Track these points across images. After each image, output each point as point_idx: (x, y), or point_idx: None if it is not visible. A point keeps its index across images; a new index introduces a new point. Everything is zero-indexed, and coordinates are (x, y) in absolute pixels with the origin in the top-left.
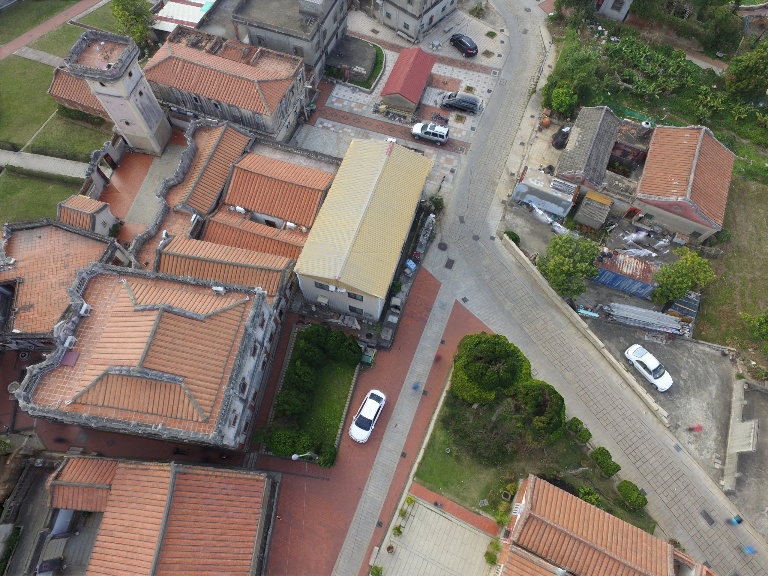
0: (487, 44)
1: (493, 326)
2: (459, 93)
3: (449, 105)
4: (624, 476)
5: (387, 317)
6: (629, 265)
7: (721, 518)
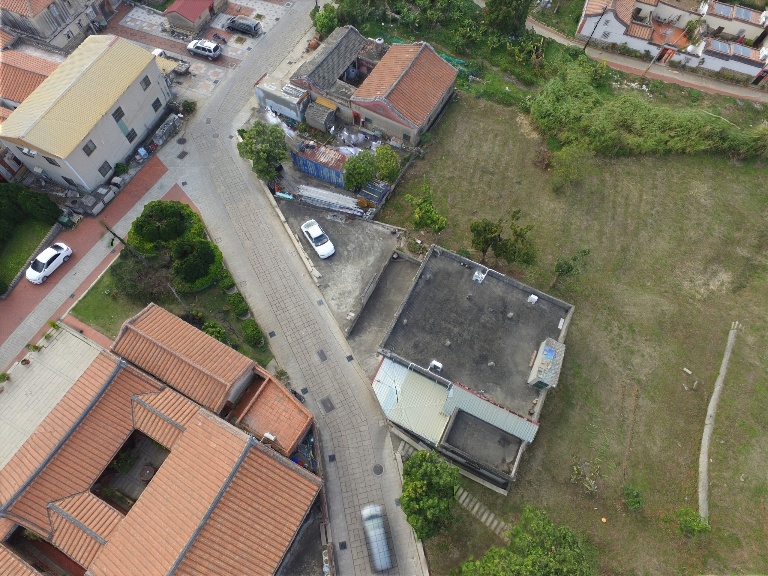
0: None
1: (199, 204)
2: (238, 16)
3: (231, 28)
4: (261, 321)
5: (97, 189)
6: (327, 155)
7: (334, 357)
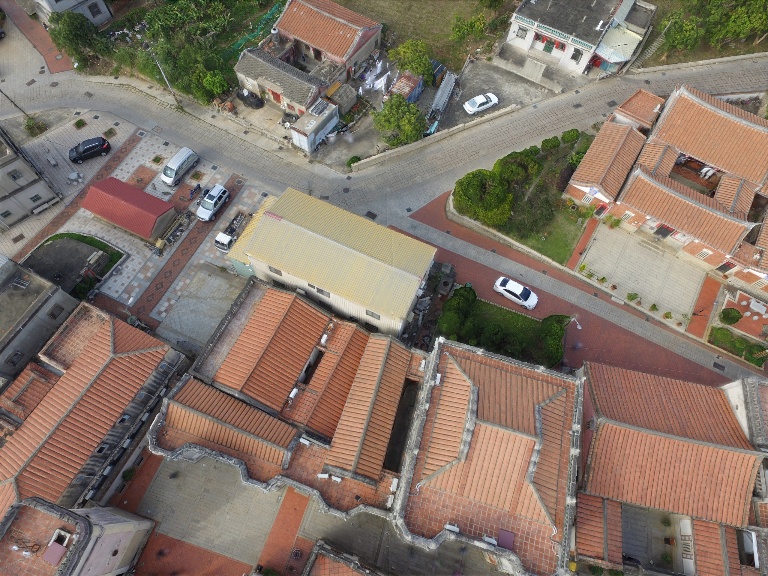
0: (94, 131)
1: (436, 194)
2: (170, 165)
3: (177, 181)
4: None
5: None
6: (402, 87)
7: (577, 100)
